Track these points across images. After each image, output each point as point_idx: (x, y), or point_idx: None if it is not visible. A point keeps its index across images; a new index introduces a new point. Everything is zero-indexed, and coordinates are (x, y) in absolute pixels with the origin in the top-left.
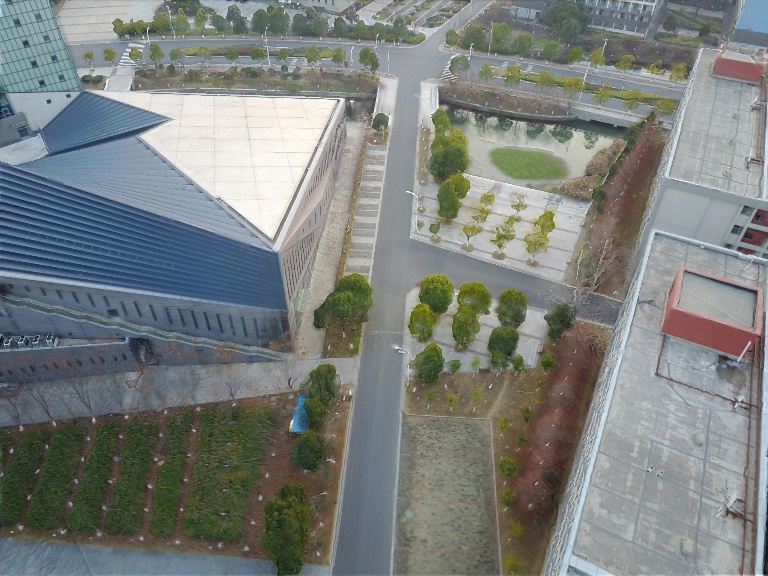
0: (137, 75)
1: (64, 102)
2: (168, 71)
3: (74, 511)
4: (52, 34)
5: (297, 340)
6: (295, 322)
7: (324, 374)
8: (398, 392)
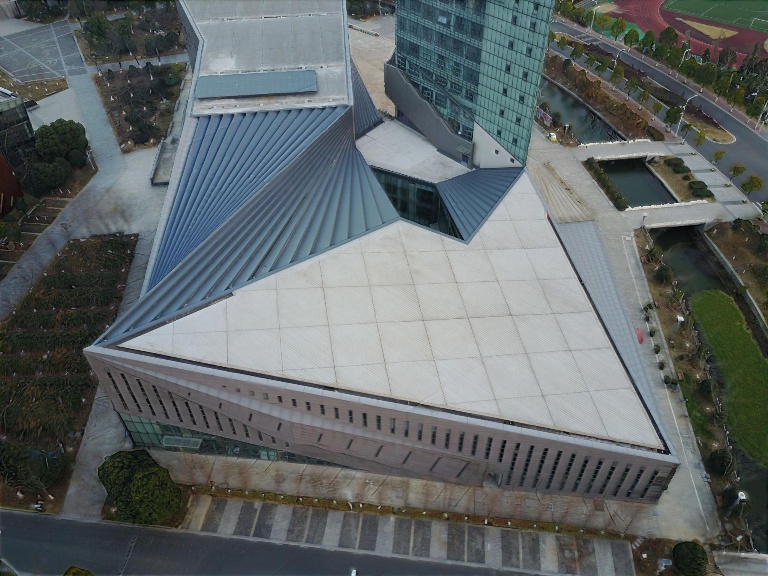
0: (734, 222)
1: (507, 162)
2: (758, 246)
3: (23, 313)
4: (528, 98)
5: (148, 449)
6: (157, 438)
7: (13, 454)
8: (23, 568)
